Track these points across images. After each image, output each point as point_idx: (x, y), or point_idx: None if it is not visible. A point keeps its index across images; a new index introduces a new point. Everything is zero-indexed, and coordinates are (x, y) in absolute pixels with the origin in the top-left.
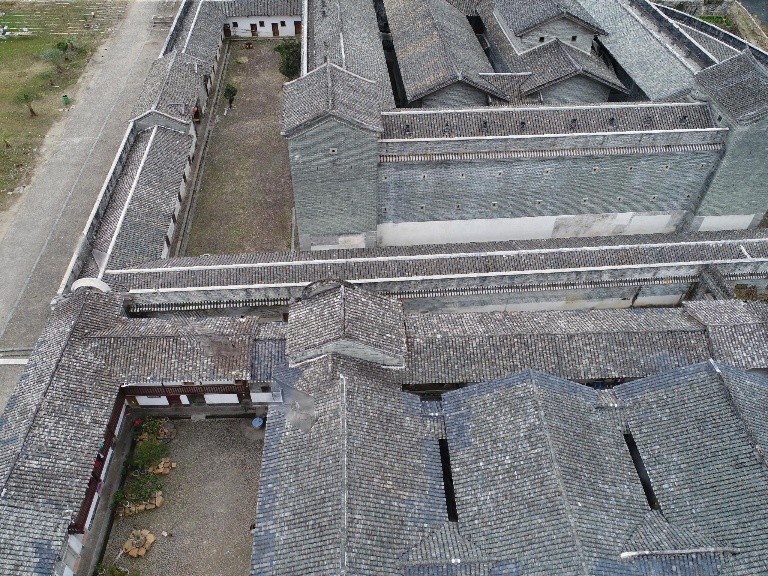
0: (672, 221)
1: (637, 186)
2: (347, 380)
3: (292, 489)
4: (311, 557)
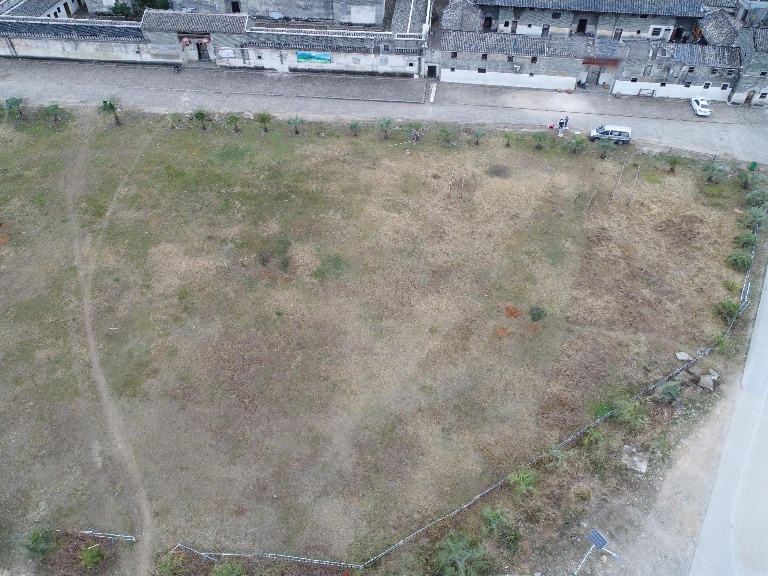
0: None
1: None
2: None
3: None
4: None
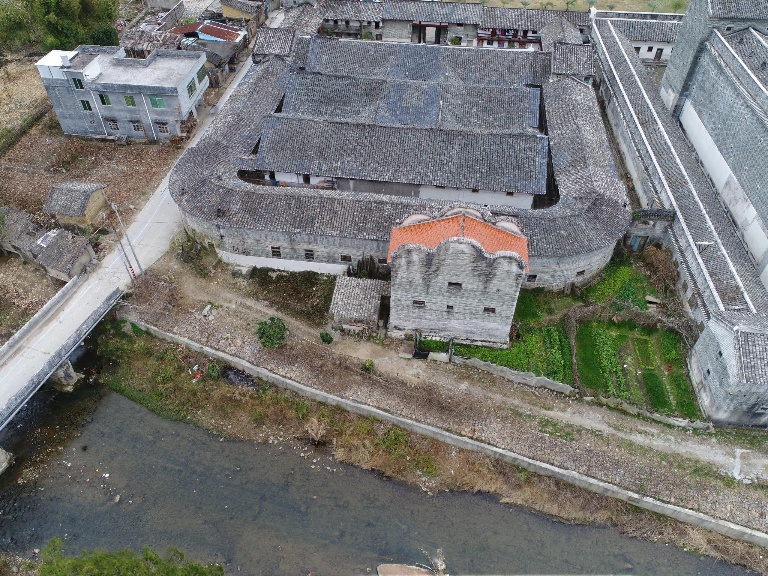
0: None
1: None
2: (533, 52)
3: None
4: None
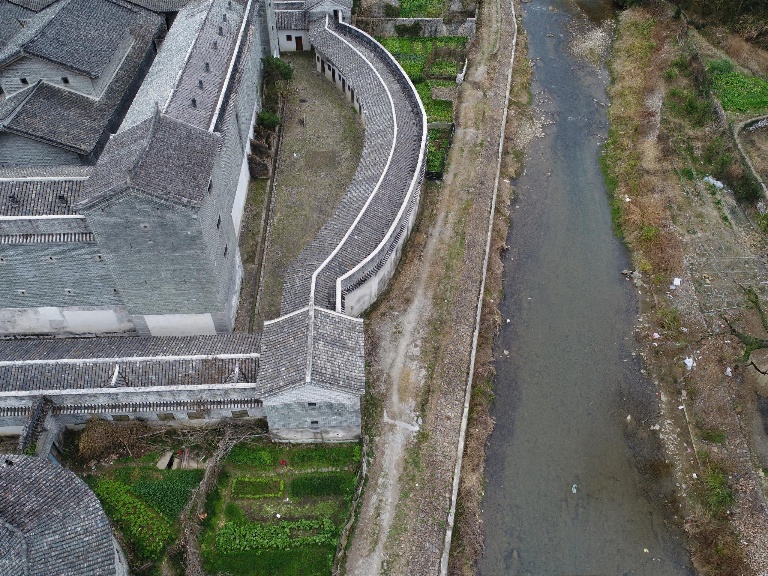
0: (121, 317)
1: (32, 279)
2: None
3: None
4: None
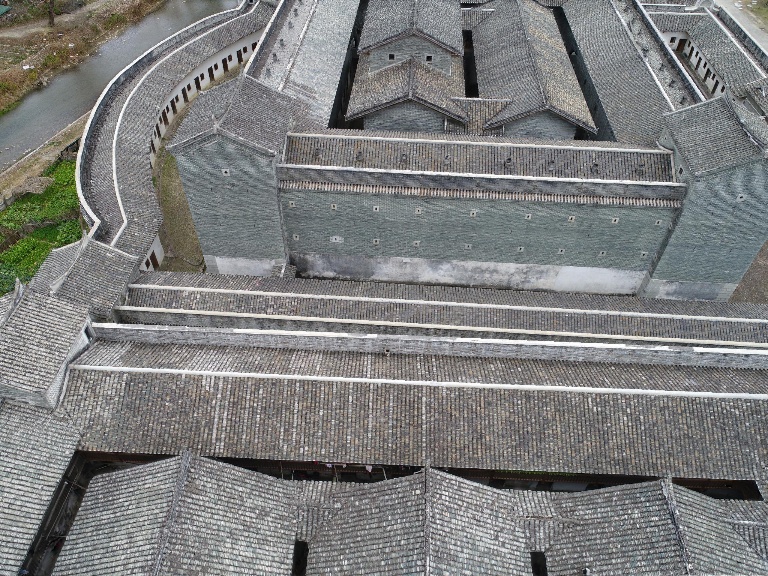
0: None
1: None
2: None
3: None
4: None
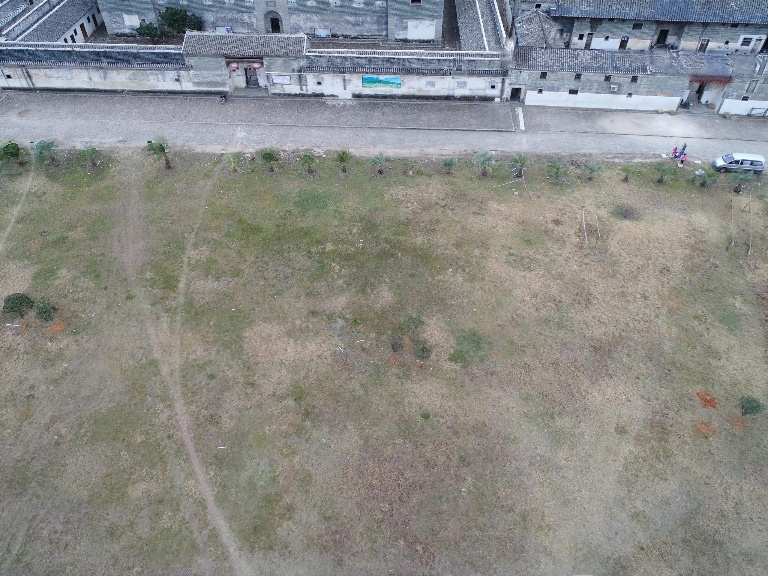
0: None
1: None
2: None
3: (618, 7)
4: (645, 1)
